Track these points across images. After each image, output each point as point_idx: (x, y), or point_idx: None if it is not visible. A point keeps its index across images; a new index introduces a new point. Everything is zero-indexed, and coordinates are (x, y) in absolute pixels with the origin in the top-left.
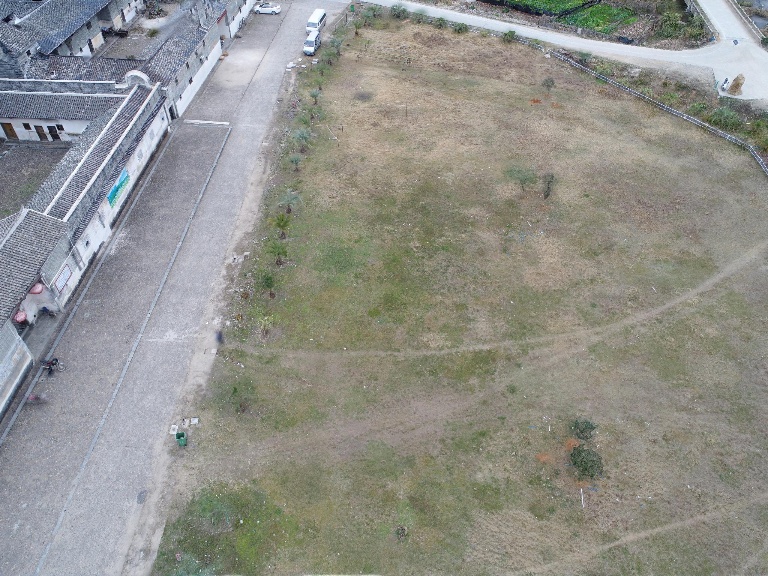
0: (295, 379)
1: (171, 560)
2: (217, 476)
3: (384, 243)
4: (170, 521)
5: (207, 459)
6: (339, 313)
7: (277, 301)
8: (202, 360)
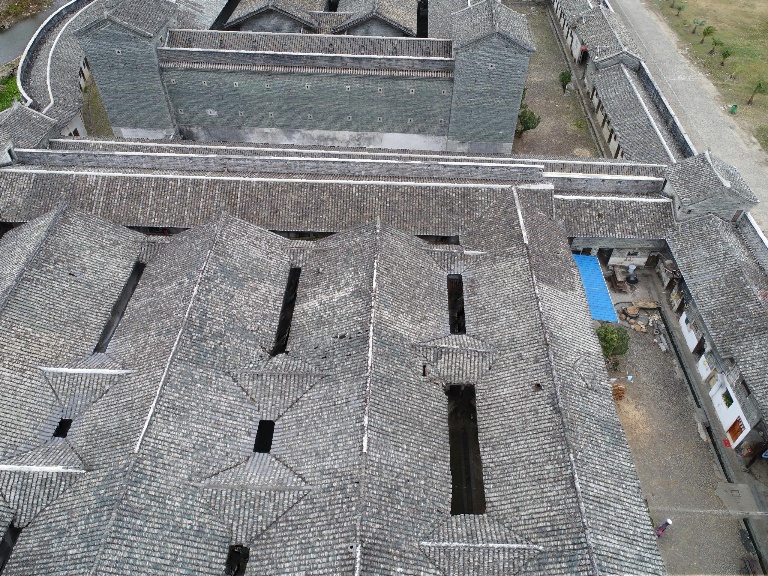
0: (767, 95)
1: (767, 145)
2: (761, 123)
3: (766, 47)
4: (754, 134)
5: (750, 118)
6: (767, 72)
7: (726, 68)
8: (709, 87)
